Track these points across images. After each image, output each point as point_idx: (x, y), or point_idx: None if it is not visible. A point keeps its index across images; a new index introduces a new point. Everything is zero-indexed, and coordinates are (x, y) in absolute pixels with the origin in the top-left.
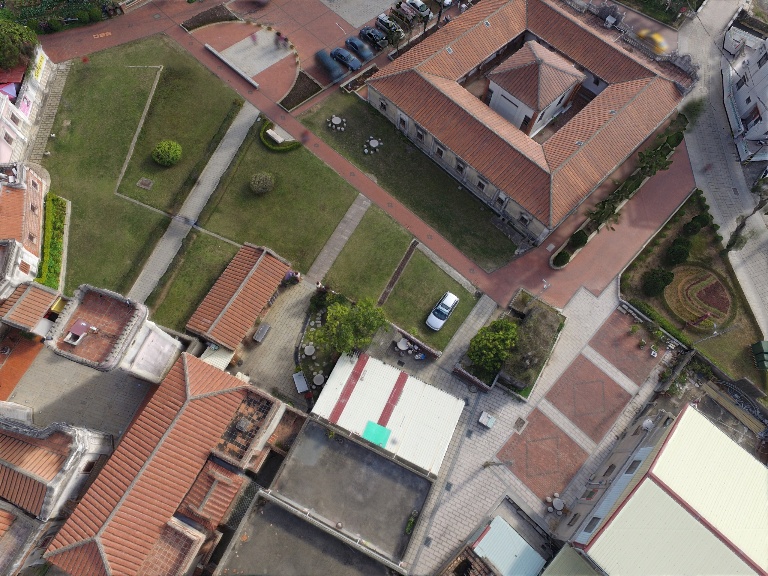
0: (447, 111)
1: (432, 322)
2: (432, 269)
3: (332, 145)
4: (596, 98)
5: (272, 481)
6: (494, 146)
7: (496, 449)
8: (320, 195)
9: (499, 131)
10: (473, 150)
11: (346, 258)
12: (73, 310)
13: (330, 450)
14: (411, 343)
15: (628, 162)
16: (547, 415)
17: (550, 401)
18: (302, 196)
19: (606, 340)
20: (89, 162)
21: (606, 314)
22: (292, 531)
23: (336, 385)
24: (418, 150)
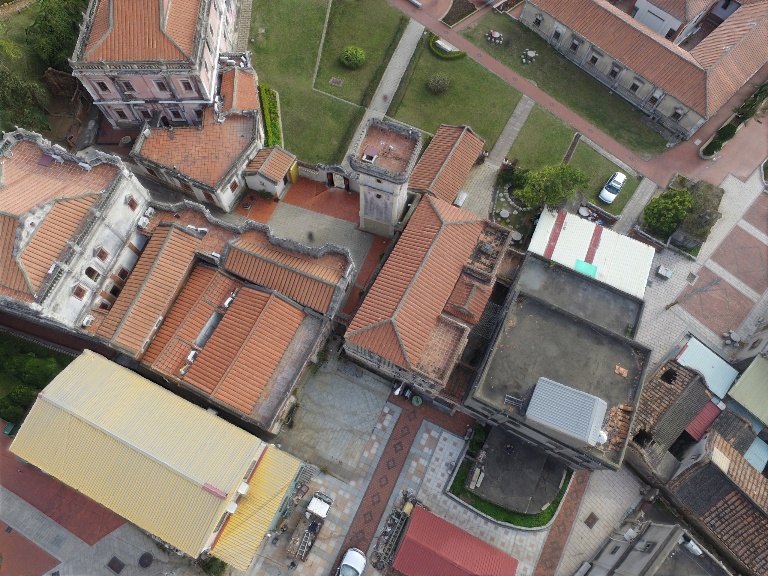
0: (605, 21)
1: (605, 196)
2: (596, 156)
3: (493, 55)
4: (732, 15)
5: (509, 297)
6: (651, 50)
7: (674, 296)
8: (489, 95)
9: (654, 38)
10: (631, 54)
11: (520, 145)
12: (363, 139)
13: (550, 279)
14: (591, 211)
15: (757, 75)
16: (714, 272)
17: (715, 261)
18: (474, 96)
19: (757, 215)
20: (287, 62)
21: (754, 196)
22: (549, 320)
23: (544, 232)
24: (569, 61)
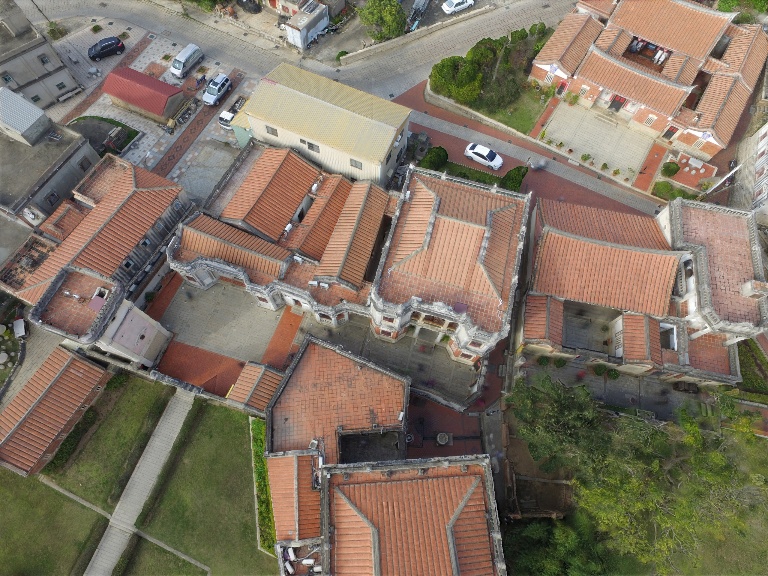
0: None
1: None
2: None
3: None
4: None
5: None
6: None
7: None
8: None
9: None
10: None
11: None
12: None
13: None
14: None
15: None
16: None
17: None
18: None
19: None
20: None
21: None
22: None
23: None
24: None
